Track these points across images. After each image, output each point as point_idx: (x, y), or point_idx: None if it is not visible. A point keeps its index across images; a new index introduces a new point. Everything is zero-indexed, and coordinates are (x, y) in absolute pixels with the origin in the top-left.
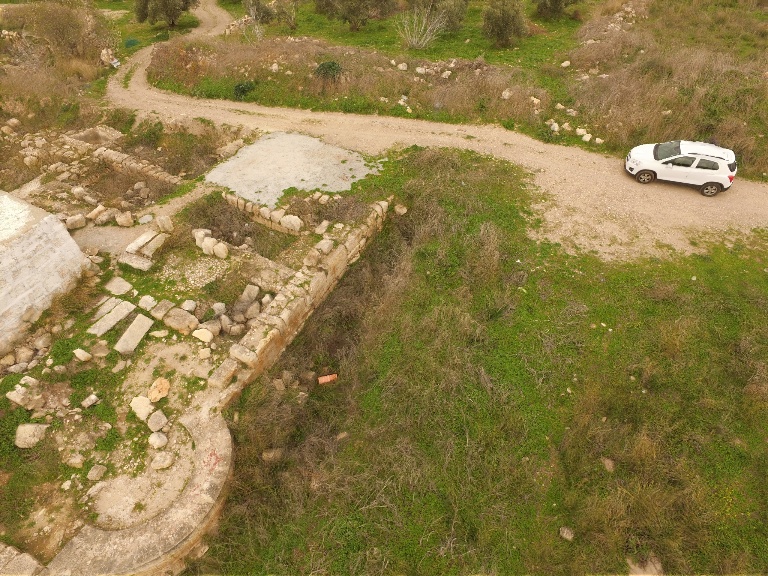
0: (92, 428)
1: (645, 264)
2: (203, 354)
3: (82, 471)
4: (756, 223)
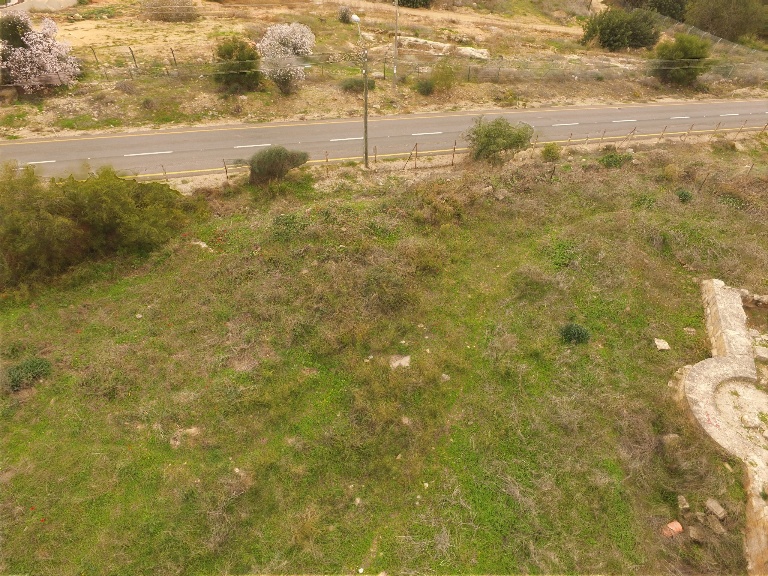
0: None
1: None
2: None
3: None
4: None
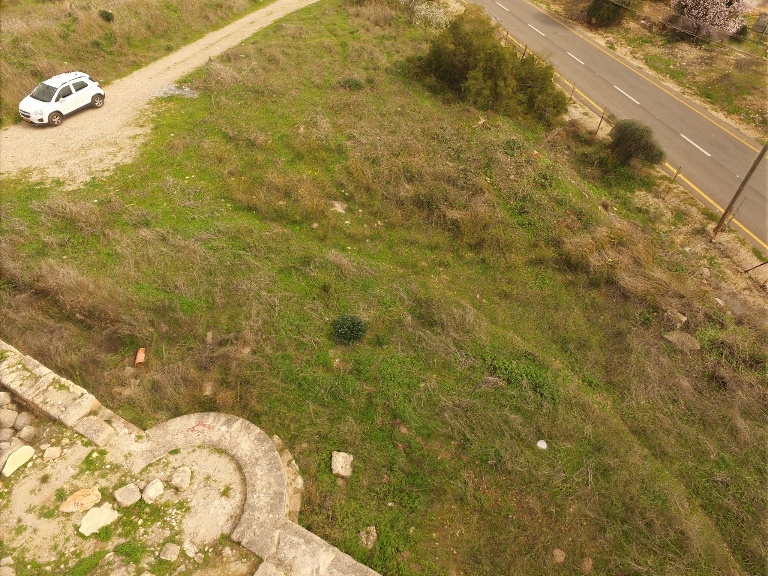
0: (107, 567)
1: (146, 148)
2: (54, 452)
3: (161, 574)
4: (143, 101)
